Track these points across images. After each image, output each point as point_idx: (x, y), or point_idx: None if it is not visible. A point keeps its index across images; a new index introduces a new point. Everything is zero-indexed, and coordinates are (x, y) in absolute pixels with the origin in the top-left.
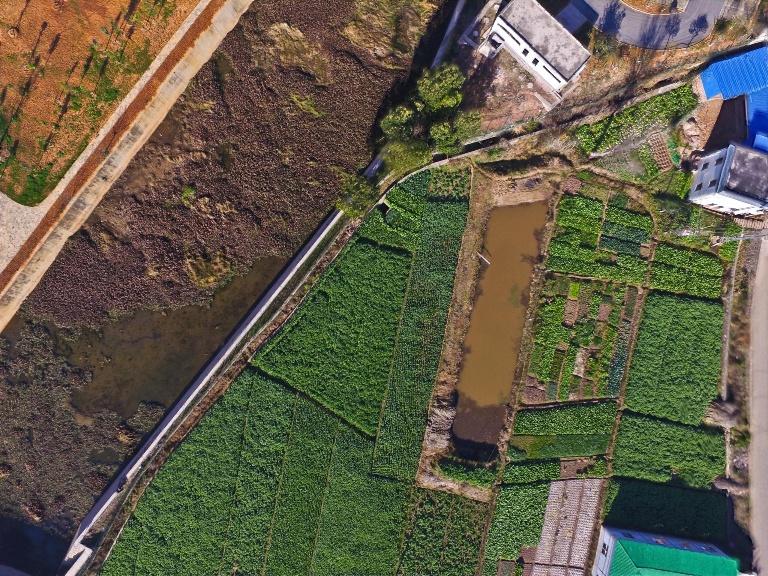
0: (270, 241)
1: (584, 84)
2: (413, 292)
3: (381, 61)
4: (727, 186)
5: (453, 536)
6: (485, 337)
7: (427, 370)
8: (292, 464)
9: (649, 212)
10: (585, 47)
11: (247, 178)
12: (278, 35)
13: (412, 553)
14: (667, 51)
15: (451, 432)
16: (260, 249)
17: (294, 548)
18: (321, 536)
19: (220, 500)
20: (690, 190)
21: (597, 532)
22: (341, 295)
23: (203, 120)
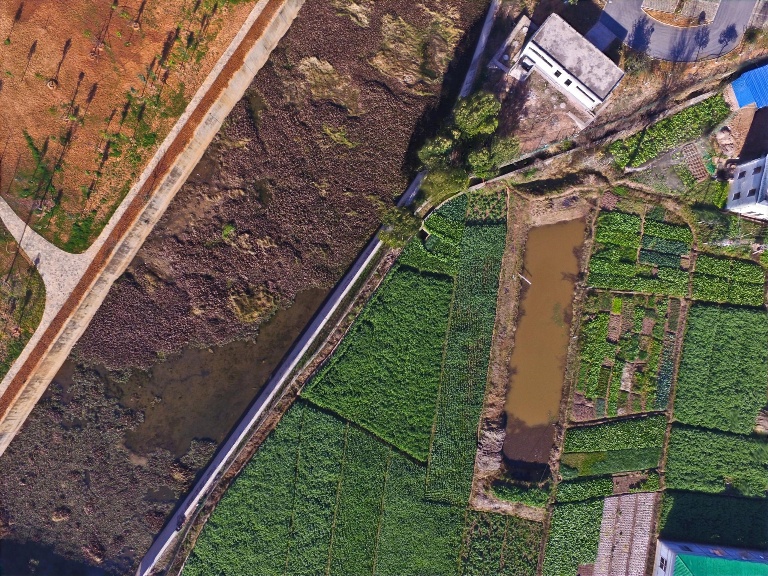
0: (311, 273)
1: (616, 101)
2: (456, 316)
3: (411, 88)
4: (767, 195)
5: (509, 557)
6: (530, 357)
7: (475, 393)
8: (346, 494)
9: (687, 223)
10: (616, 64)
11: (285, 212)
12: (308, 69)
13: None
14: (698, 63)
15: (502, 454)
16: (302, 282)
17: None
18: (379, 564)
19: (278, 533)
20: (727, 199)
21: (653, 546)
22: (385, 324)
23: (239, 158)
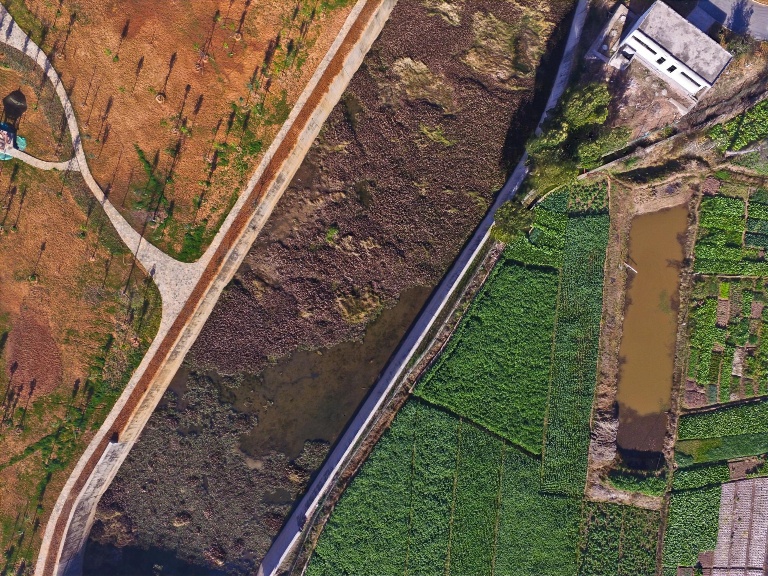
0: (415, 272)
1: (718, 84)
2: (563, 308)
3: (505, 84)
4: None
5: (628, 547)
6: (639, 346)
7: (586, 384)
8: (463, 489)
9: None
10: None
11: (387, 213)
12: (402, 70)
13: (589, 567)
14: None
15: (616, 444)
16: (406, 281)
17: (473, 572)
18: (499, 558)
19: (397, 531)
20: None
21: None
22: (494, 318)
23: (339, 161)
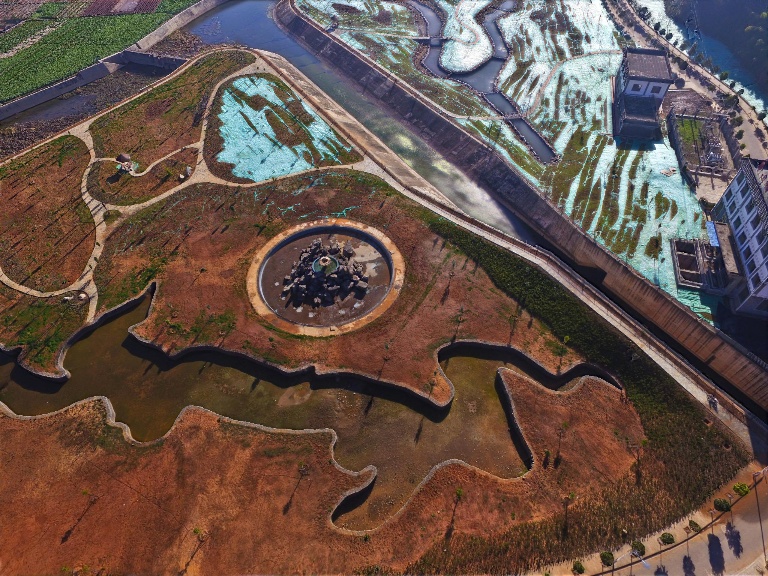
0: None
1: None
2: None
3: None
4: None
5: None
6: None
7: None
8: (4, 81)
9: None
10: None
11: None
12: None
13: None
14: None
15: None
16: None
17: None
18: (6, 67)
19: None
20: None
21: None
22: None
23: None
